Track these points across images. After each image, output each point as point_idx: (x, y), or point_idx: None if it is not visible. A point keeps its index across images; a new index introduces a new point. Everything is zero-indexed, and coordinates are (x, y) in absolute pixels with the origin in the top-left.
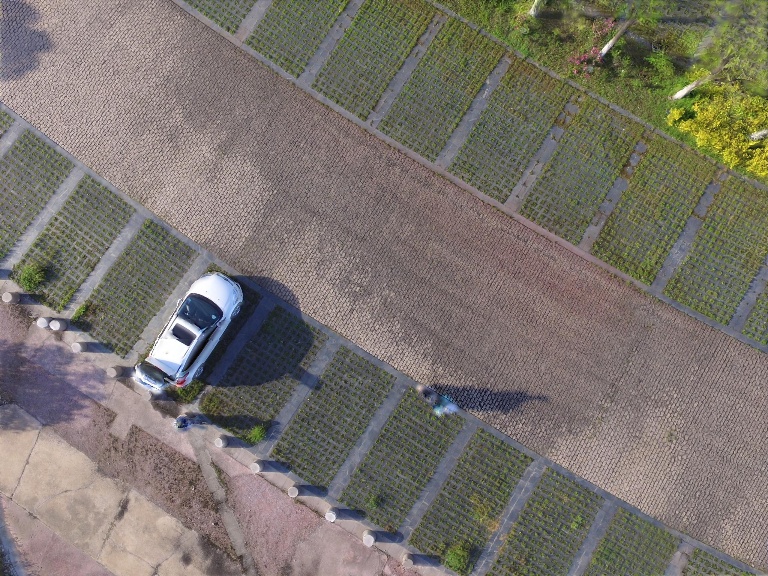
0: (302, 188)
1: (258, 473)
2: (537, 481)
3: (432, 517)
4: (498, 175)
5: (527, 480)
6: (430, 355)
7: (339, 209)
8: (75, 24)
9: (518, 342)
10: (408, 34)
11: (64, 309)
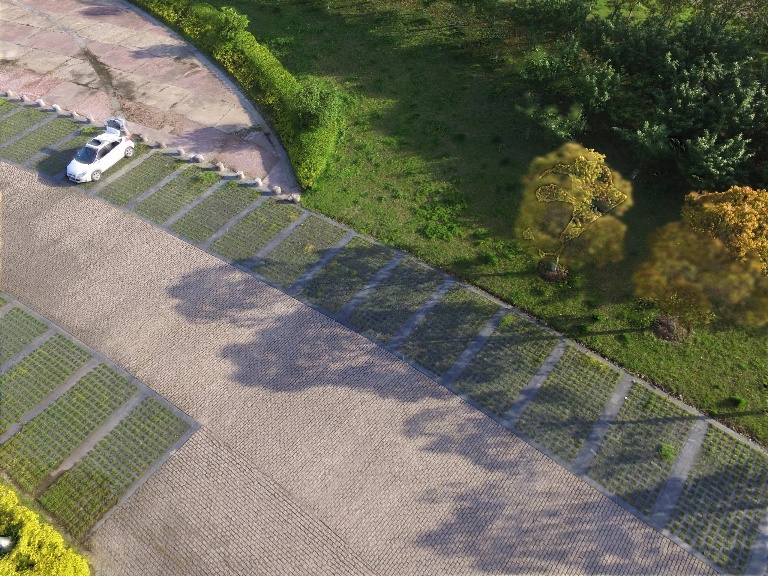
0: (8, 228)
1: None
2: None
3: (4, 113)
4: None
5: None
6: None
7: None
8: None
9: None
10: None
11: None
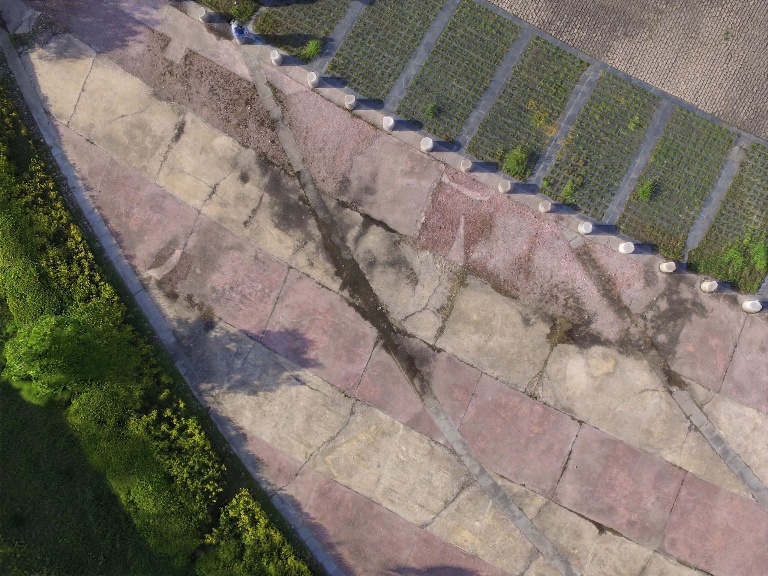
0: None
1: (314, 89)
2: (593, 85)
3: (489, 125)
4: None
5: (583, 84)
6: None
7: None
8: None
9: None
10: None
11: None
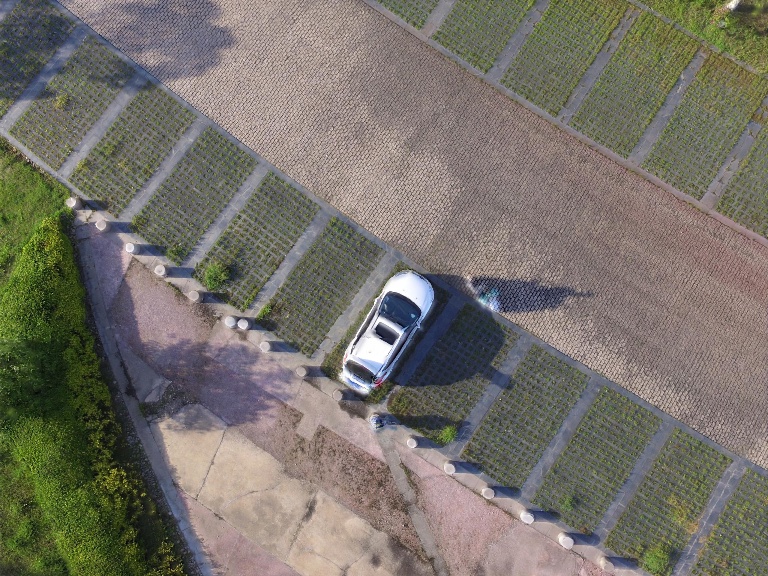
0: (490, 185)
1: (449, 474)
2: (737, 483)
3: (629, 519)
4: (693, 172)
5: (727, 482)
6: (625, 354)
7: (529, 206)
8: (257, 20)
9: (716, 341)
10: (599, 29)
11: (248, 308)
